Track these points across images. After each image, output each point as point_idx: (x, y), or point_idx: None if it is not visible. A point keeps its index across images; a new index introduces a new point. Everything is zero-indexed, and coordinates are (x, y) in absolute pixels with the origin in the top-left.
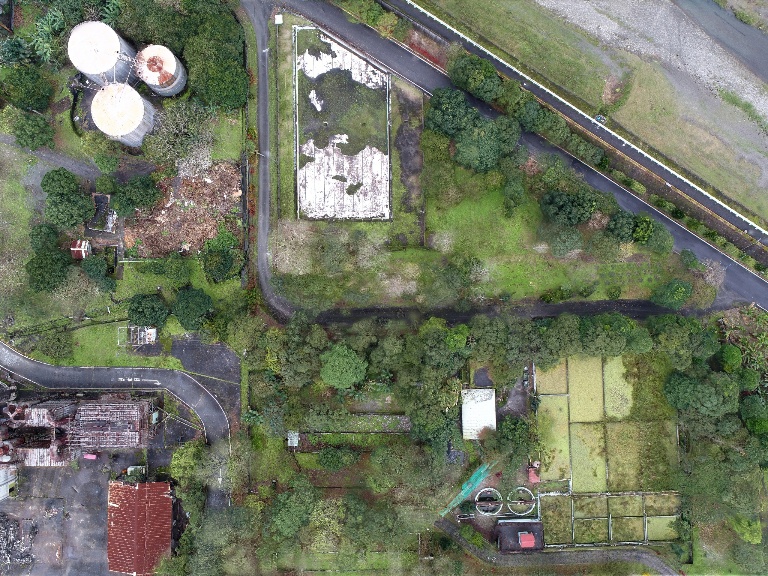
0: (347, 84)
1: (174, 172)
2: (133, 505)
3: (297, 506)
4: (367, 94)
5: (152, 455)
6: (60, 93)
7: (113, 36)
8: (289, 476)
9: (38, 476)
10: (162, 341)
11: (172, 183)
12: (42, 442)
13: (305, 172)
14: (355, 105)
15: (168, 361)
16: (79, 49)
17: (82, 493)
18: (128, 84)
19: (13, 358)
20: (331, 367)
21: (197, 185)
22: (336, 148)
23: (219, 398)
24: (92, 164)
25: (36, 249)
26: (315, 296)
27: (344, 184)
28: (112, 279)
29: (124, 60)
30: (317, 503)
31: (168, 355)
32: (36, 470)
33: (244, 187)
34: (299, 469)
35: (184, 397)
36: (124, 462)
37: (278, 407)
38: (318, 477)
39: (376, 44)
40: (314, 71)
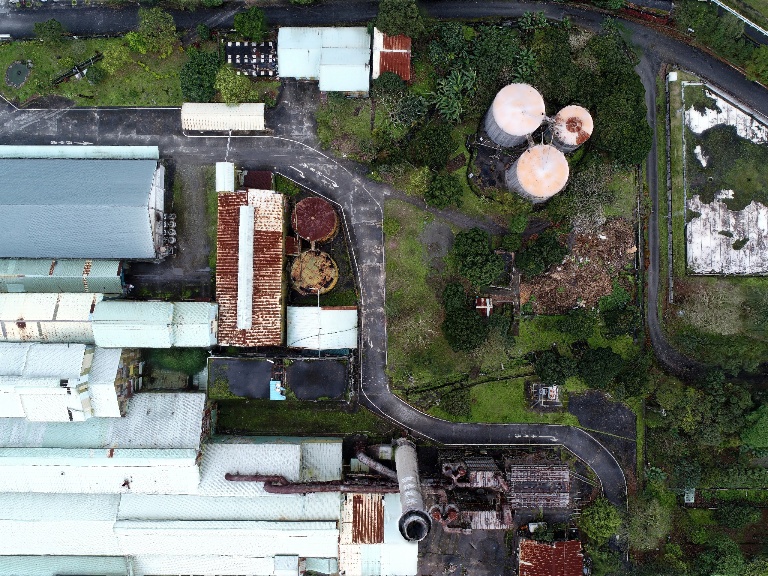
0: (732, 139)
1: (569, 229)
2: (550, 564)
3: (730, 567)
4: (752, 149)
5: (548, 511)
6: (456, 150)
7: (538, 98)
8: (682, 532)
9: (436, 532)
10: (559, 397)
11: (566, 240)
12: (470, 503)
13: (691, 227)
14: (740, 160)
15: (565, 417)
16: (506, 111)
17: (479, 549)
18: (553, 145)
19: (411, 415)
20: (763, 428)
21: (593, 242)
22: (722, 203)
23: (615, 454)
24: (487, 221)
25: (451, 308)
26: (738, 356)
27: (730, 239)
28: (512, 336)
29: (548, 121)
30: (749, 564)
31: (564, 411)
32: (434, 526)
33: (636, 243)
34: (692, 525)
35: (581, 453)
36: (521, 518)
37: (692, 466)
38: (711, 533)
39: (764, 100)
40: (699, 127)
